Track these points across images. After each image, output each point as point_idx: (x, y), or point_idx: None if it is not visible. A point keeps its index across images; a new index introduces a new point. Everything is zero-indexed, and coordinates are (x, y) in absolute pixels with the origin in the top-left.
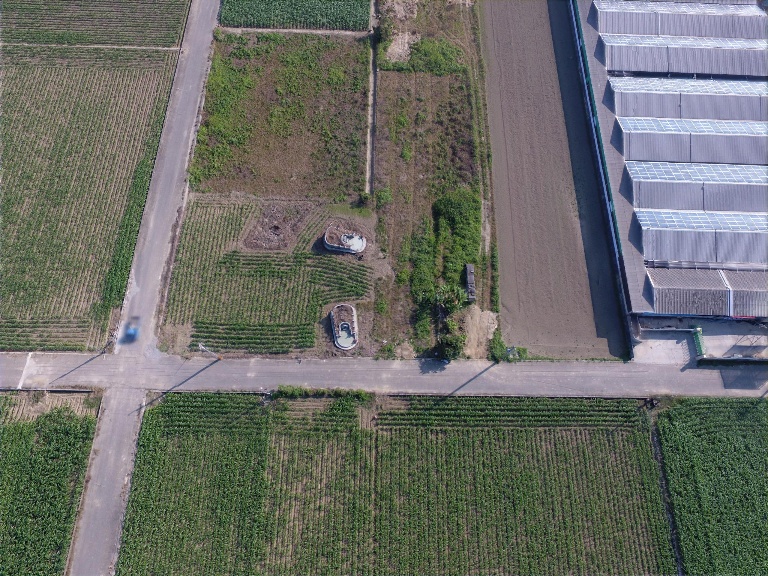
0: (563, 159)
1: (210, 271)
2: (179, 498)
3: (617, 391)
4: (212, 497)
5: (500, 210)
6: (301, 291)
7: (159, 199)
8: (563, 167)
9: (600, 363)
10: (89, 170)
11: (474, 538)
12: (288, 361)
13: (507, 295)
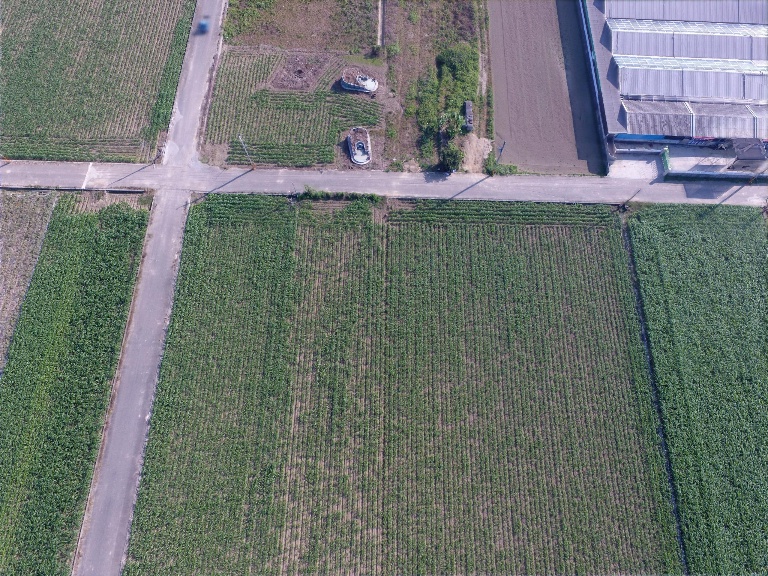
0: (552, 23)
1: (243, 105)
2: (221, 269)
3: (594, 198)
4: (249, 269)
5: (496, 62)
6: (322, 120)
7: (197, 48)
8: (552, 29)
9: (580, 177)
10: (135, 26)
11: (470, 303)
12: (311, 172)
13: (501, 126)
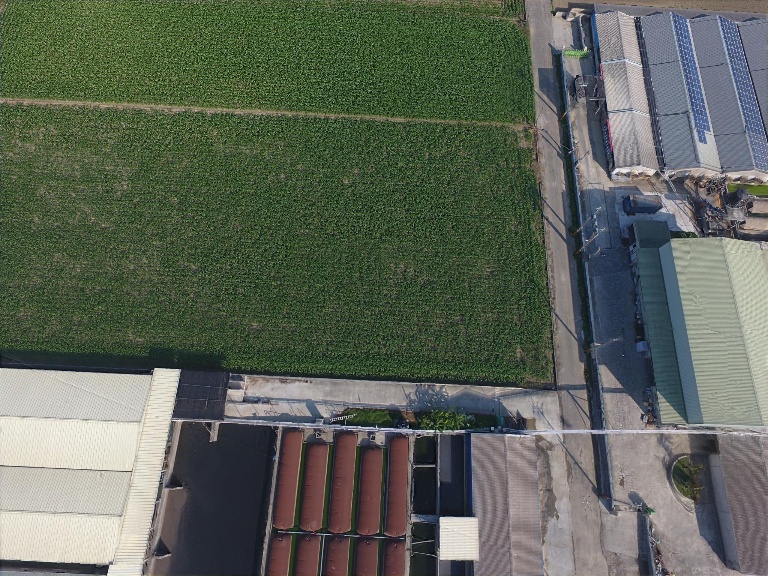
0: (726, 6)
1: None
2: None
3: (530, 3)
4: None
5: None
6: None
7: None
8: (718, 5)
9: None
10: None
11: None
12: None
13: None
